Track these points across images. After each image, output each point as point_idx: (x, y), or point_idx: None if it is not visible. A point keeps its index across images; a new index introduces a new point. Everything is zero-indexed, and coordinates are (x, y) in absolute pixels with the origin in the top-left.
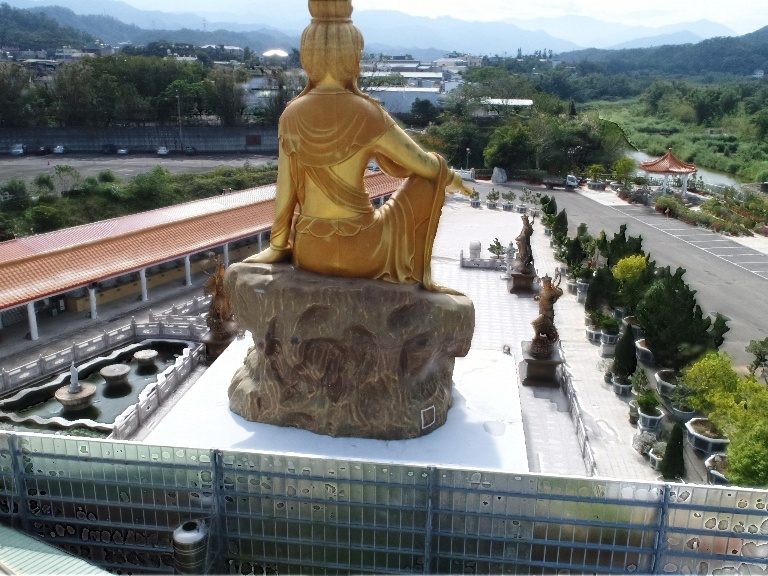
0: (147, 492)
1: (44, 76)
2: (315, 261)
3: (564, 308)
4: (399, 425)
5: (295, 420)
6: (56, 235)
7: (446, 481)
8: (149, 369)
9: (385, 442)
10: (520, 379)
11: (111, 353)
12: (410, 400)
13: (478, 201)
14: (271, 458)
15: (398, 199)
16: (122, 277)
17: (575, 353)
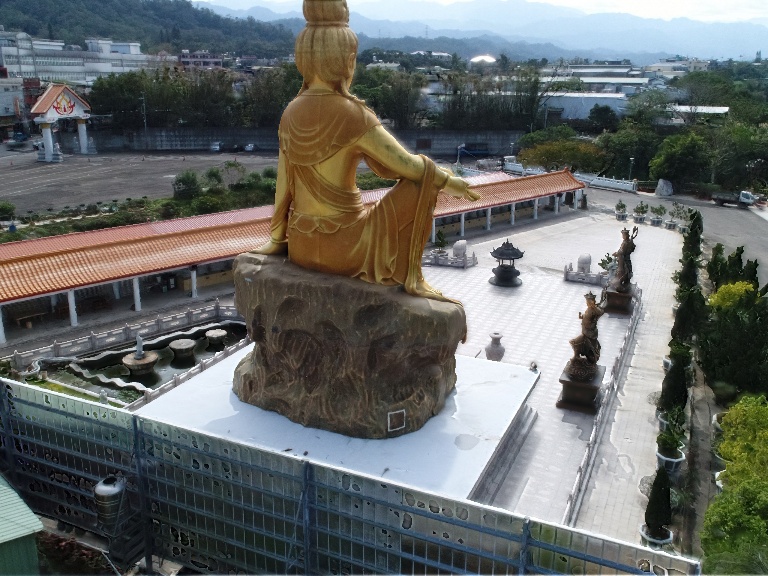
0: (92, 445)
1: (244, 81)
2: (300, 255)
3: (656, 333)
4: (363, 424)
5: (277, 406)
6: (182, 221)
7: (320, 477)
8: (217, 347)
9: (349, 438)
10: (557, 400)
11: (191, 329)
12: (378, 401)
13: (624, 214)
14: (178, 430)
15: (383, 200)
16: (231, 263)
17: (639, 381)
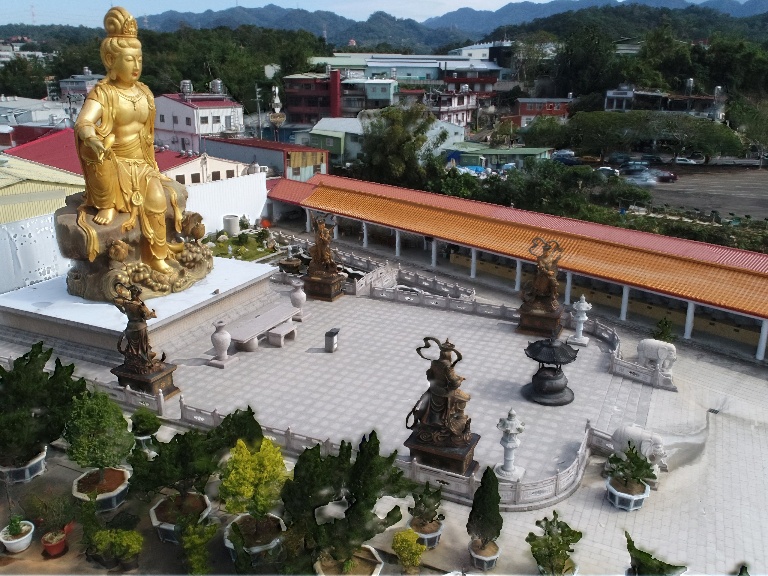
0: None
1: None
2: None
3: None
4: None
5: None
6: (525, 213)
7: None
8: None
9: None
10: None
11: None
12: None
13: None
14: None
15: None
16: None
17: None
